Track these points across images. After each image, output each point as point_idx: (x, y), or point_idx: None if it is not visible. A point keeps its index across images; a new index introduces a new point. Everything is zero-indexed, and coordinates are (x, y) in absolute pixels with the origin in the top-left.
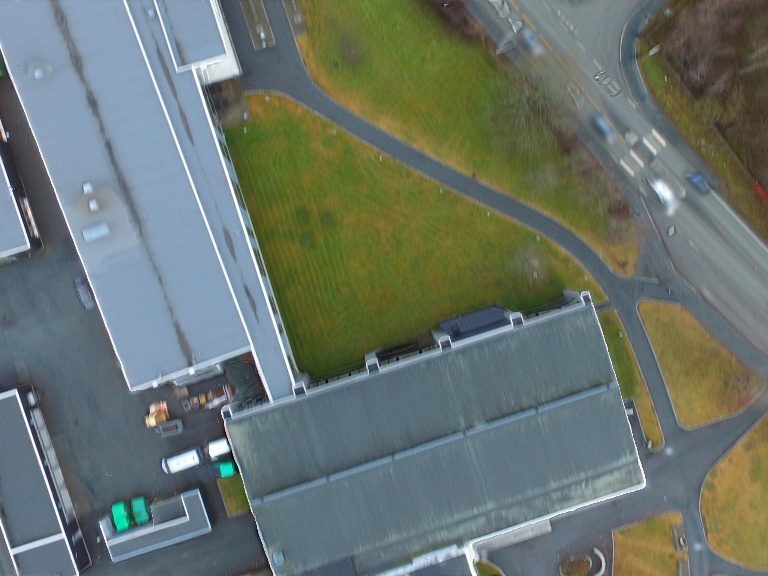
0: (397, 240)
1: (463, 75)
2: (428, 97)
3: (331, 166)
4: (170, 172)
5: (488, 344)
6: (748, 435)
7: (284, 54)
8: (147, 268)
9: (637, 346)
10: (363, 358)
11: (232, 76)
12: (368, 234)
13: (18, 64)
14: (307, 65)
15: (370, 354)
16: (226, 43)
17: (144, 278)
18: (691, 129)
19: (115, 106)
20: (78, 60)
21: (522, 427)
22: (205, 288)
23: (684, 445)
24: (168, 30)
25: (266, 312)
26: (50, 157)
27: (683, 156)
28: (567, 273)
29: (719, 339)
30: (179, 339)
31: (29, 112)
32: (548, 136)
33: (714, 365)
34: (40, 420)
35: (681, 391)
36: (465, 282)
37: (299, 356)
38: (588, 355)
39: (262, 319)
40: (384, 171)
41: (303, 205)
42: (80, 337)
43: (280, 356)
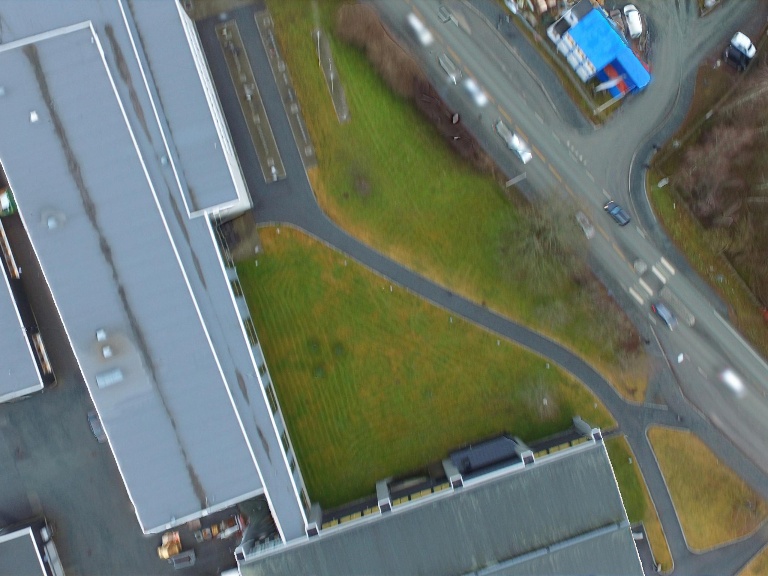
0: (408, 368)
1: (473, 206)
2: (438, 227)
3: (342, 296)
4: (183, 317)
5: (499, 484)
6: (757, 558)
7: (295, 186)
8: (160, 412)
9: (646, 471)
10: (374, 489)
11: (243, 212)
12: (379, 363)
13: (32, 213)
14: (318, 197)
15: (381, 484)
16: (238, 182)
17: (157, 422)
18: (700, 256)
19: (128, 253)
20: (91, 207)
21: (534, 566)
22: (218, 431)
23: (693, 568)
24: (181, 176)
25: (279, 454)
26: (64, 304)
27: (692, 284)
28: (577, 399)
29: (728, 464)
30: (192, 482)
31: (43, 260)
32: (558, 266)
33: (723, 490)
34: (53, 552)
35: (690, 515)
36: (475, 409)
37: (311, 485)
38: (599, 494)
39: (275, 460)
40: (395, 300)
41: (314, 335)
42: (93, 469)
43: (293, 497)
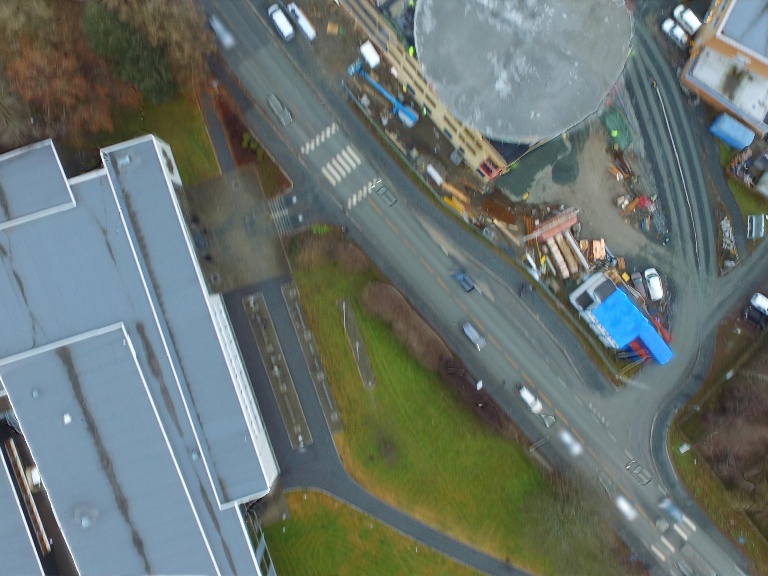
0: None
1: (497, 467)
2: (462, 488)
3: (368, 557)
4: None
5: None
6: None
7: (321, 451)
8: None
9: None
10: None
11: (271, 484)
12: None
13: (65, 511)
14: (344, 460)
15: None
16: (266, 462)
17: None
18: (720, 510)
19: (160, 545)
20: (124, 502)
21: None
22: None
23: None
24: (211, 468)
25: None
26: None
27: (713, 540)
28: None
29: None
30: None
31: (76, 557)
32: (581, 527)
33: None
34: None
35: None
36: None
37: None
38: None
39: None
40: (420, 560)
41: None
42: None
43: None
